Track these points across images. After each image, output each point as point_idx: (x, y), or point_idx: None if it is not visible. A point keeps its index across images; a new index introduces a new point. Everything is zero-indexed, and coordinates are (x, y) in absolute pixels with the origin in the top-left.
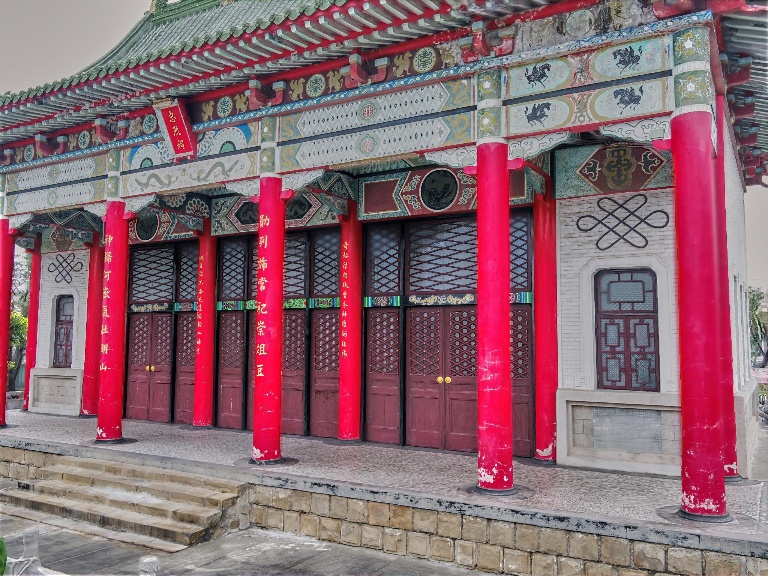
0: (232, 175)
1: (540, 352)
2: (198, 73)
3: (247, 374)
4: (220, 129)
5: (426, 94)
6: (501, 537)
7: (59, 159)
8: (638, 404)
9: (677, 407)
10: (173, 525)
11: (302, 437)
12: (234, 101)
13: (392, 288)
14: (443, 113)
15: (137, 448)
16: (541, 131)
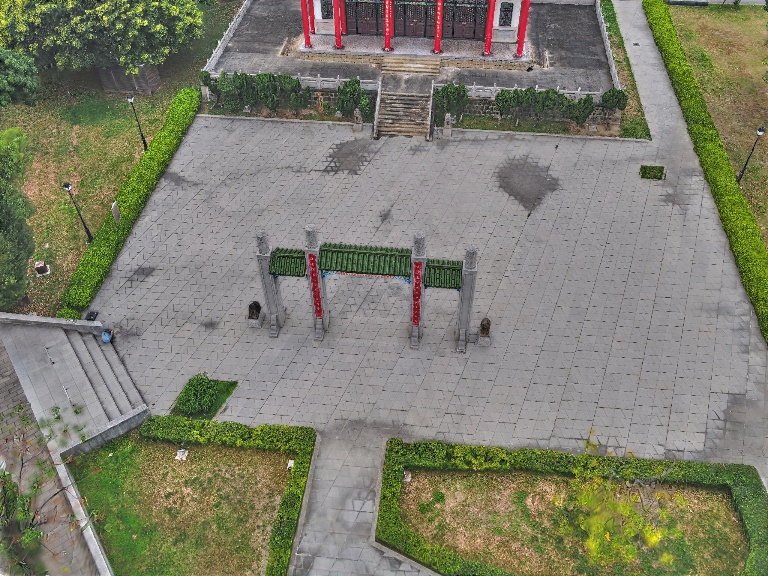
0: None
1: None
2: None
3: (405, 21)
4: None
5: None
6: (491, 64)
7: None
8: None
9: (514, 30)
10: None
11: (425, 37)
12: None
13: (452, 1)
14: None
15: (401, 52)
16: None
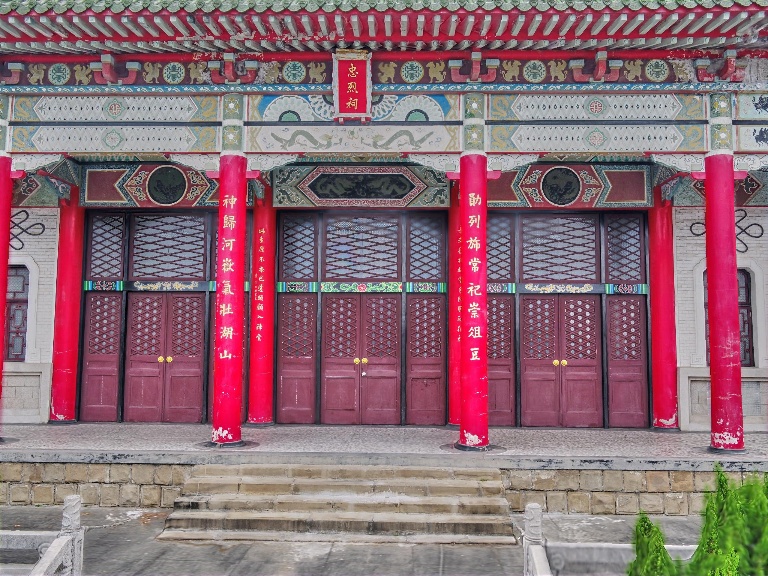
0: (425, 147)
1: (663, 336)
2: (438, 33)
3: (320, 363)
4: (406, 95)
5: (659, 101)
6: None
7: (134, 91)
8: (746, 377)
9: None
10: (473, 519)
11: (403, 426)
12: (426, 68)
13: (504, 275)
14: (676, 121)
15: (292, 448)
16: (767, 151)
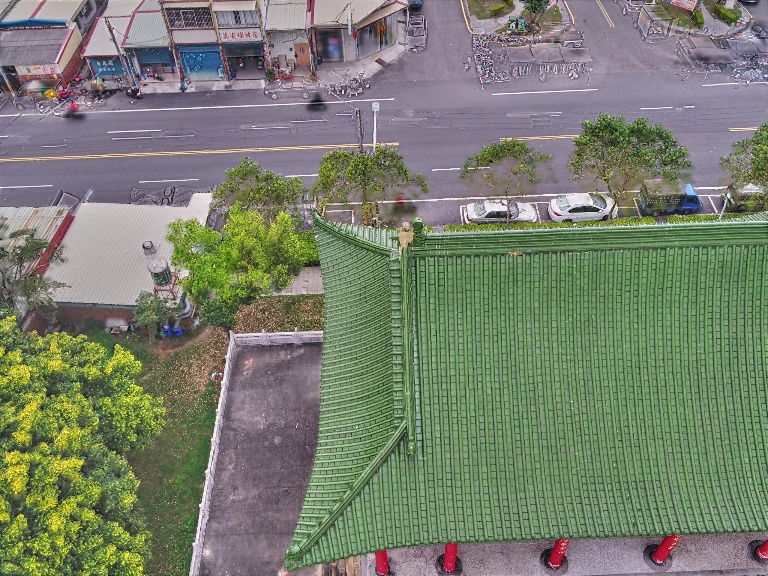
0: None
1: None
2: None
3: None
4: None
5: None
6: None
7: None
8: None
9: None
10: None
11: None
12: None
13: None
14: None
15: (584, 567)
16: None
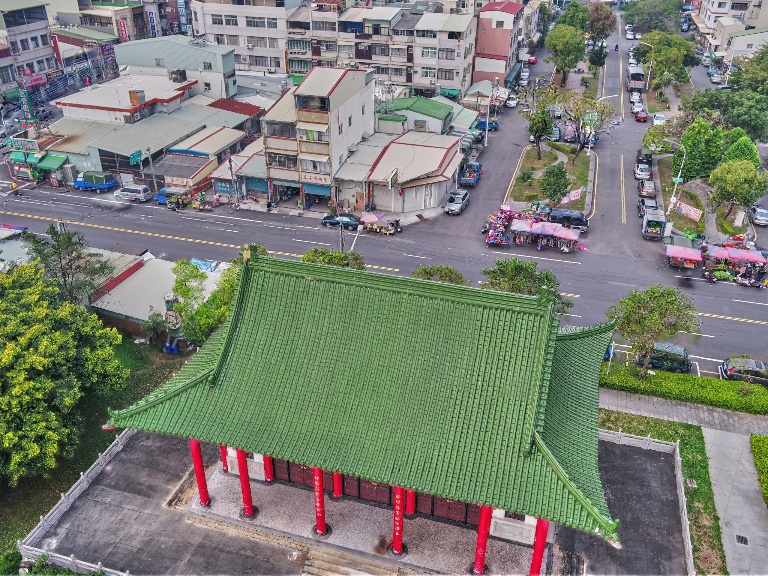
0: None
1: None
2: None
3: (359, 482)
4: None
5: None
6: None
7: None
8: None
9: None
10: None
11: (389, 507)
12: None
13: None
14: None
15: (341, 540)
16: None
